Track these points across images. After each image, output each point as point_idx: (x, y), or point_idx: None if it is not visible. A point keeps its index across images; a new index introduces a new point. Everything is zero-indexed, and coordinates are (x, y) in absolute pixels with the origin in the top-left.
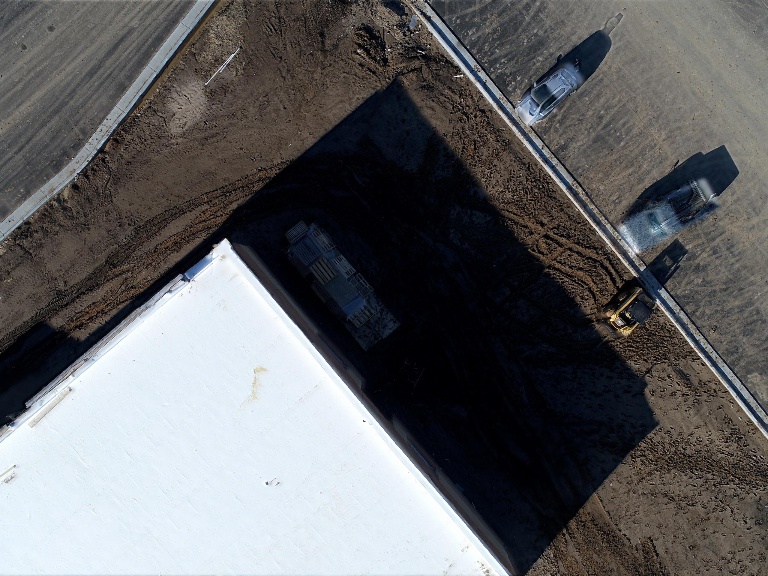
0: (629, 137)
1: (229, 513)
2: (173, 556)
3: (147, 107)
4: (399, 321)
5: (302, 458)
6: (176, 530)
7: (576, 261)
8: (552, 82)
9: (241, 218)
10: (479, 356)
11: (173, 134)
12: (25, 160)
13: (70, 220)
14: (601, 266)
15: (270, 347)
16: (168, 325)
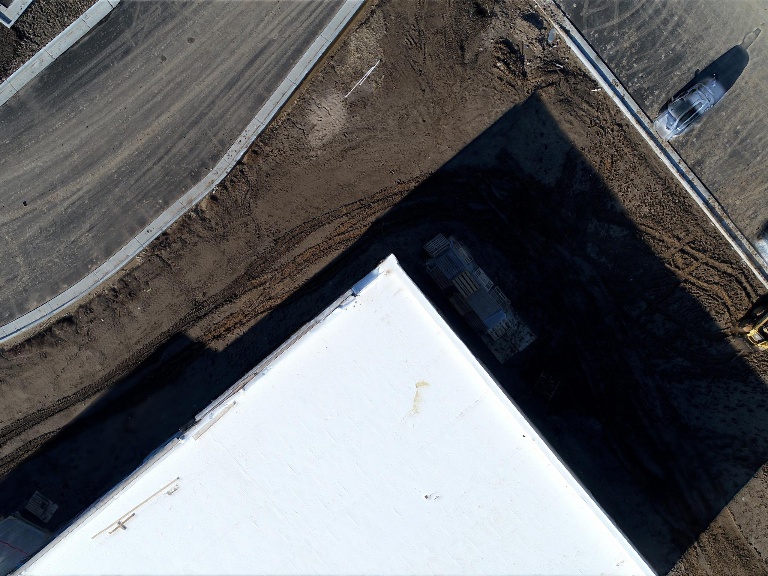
0: (765, 152)
1: (388, 526)
2: (332, 568)
3: (285, 119)
4: (535, 334)
5: (461, 472)
6: (336, 543)
7: (711, 275)
8: (689, 97)
9: (380, 230)
10: (614, 369)
11: (312, 146)
12: (164, 171)
13: (209, 231)
14: (736, 281)
15: (432, 362)
16: (332, 339)
